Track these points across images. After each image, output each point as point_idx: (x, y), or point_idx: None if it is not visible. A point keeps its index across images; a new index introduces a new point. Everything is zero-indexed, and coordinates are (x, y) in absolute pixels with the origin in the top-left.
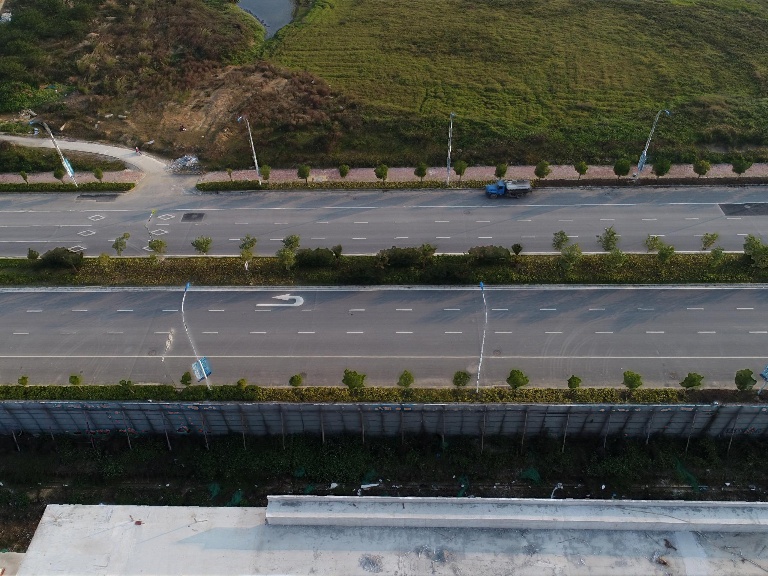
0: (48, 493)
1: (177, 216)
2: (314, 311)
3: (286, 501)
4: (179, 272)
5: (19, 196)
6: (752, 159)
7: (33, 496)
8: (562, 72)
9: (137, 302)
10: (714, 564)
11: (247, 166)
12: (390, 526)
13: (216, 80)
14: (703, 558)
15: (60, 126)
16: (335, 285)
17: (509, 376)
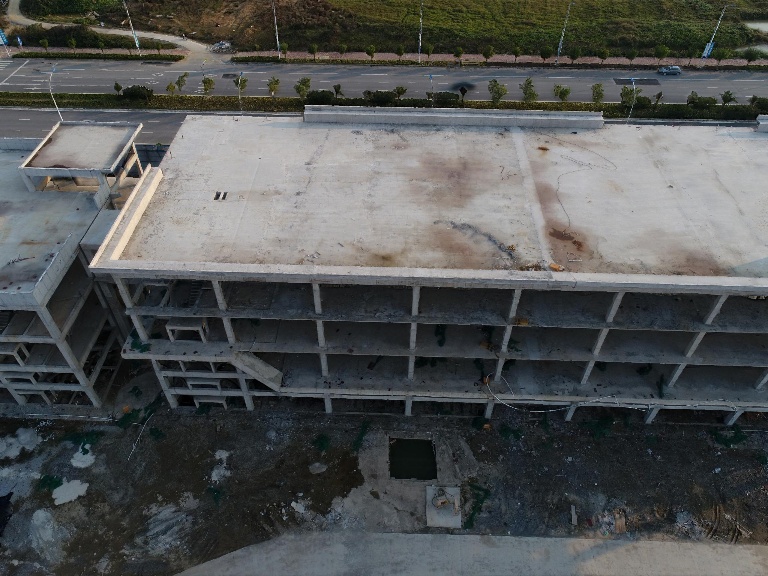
0: None
1: (218, 75)
2: None
3: (314, 109)
4: (223, 103)
5: (97, 62)
6: (644, 54)
7: None
8: (515, 1)
9: None
10: (527, 135)
11: (269, 49)
12: (367, 123)
13: None
14: (522, 133)
15: (121, 21)
16: None
17: None
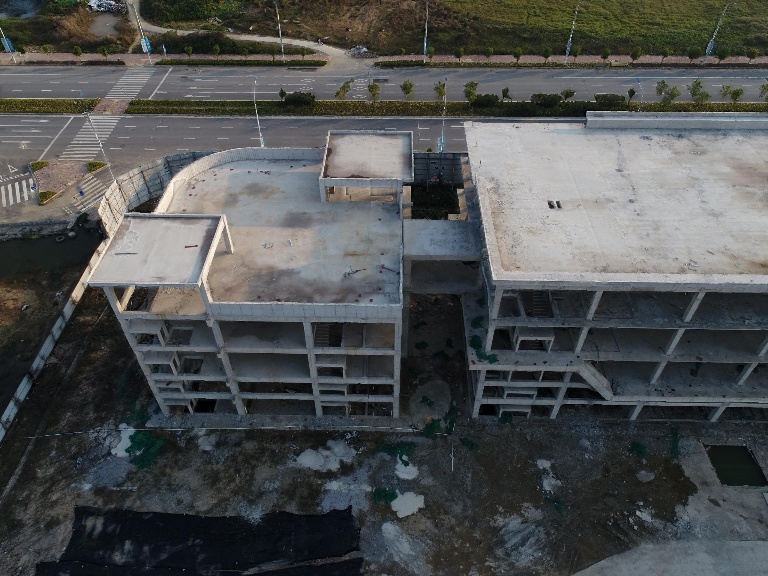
0: None
1: None
2: None
3: (596, 115)
4: (387, 109)
5: (241, 68)
6: None
7: None
8: (631, 2)
9: (365, 124)
10: None
11: (409, 52)
12: (649, 128)
13: (360, 0)
14: None
15: (249, 27)
16: (503, 116)
17: None
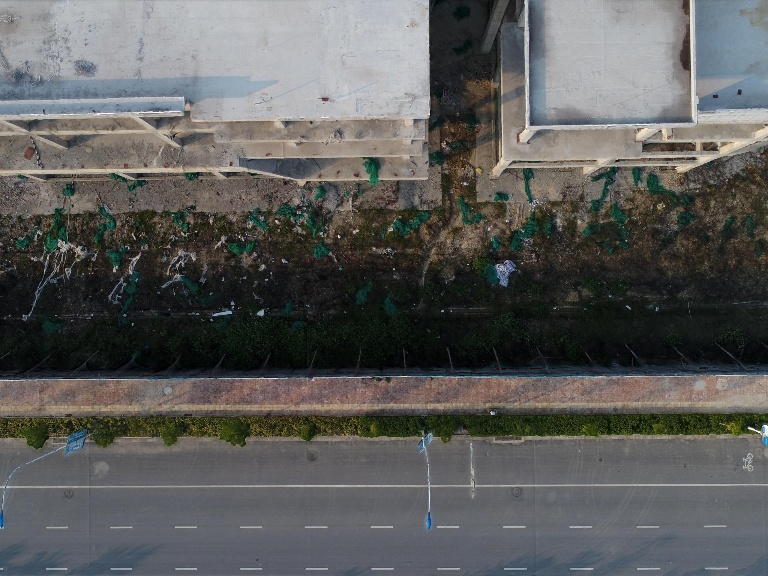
0: (569, 297)
1: None
2: (310, 567)
3: None
4: None
5: None
6: None
7: (584, 293)
8: None
9: None
10: None
11: None
12: None
13: None
14: None
15: None
16: None
17: (57, 456)
